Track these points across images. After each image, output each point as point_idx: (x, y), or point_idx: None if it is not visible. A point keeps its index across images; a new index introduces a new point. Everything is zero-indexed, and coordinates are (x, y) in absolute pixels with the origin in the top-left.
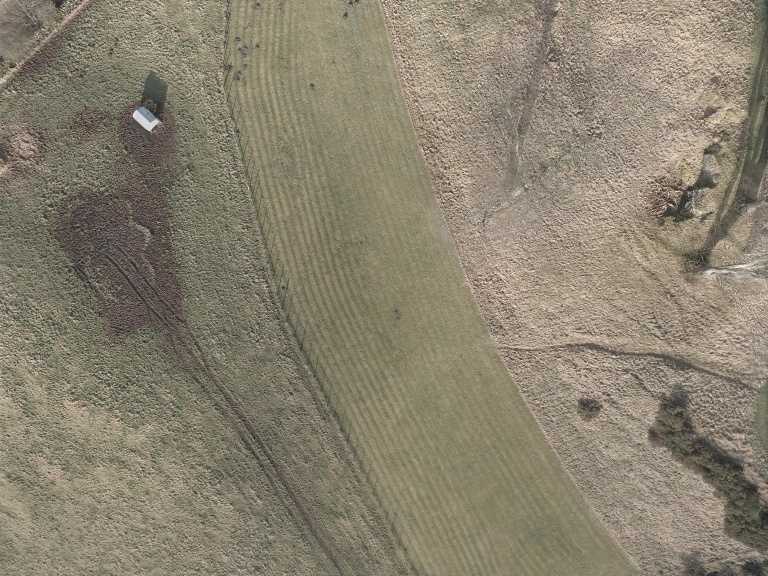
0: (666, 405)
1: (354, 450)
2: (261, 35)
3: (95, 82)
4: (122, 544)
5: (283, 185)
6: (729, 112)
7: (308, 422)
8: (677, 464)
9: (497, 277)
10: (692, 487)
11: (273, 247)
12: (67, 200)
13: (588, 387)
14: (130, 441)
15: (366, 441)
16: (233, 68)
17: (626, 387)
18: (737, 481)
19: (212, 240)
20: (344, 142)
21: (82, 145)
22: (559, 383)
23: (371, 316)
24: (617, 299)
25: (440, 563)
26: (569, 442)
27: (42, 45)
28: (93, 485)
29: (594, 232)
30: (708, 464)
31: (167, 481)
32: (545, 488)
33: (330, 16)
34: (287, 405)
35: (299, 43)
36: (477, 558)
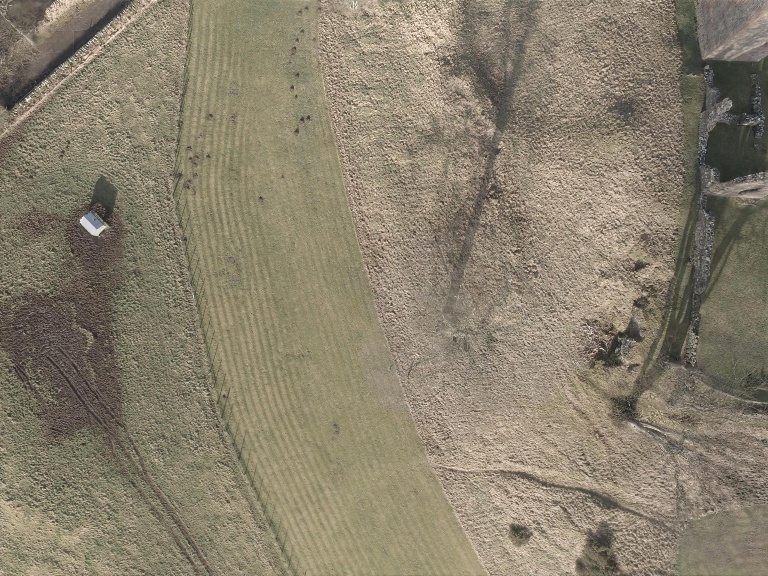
0: (592, 542)
1: (289, 559)
2: (212, 146)
3: (45, 184)
4: None
5: (228, 295)
6: (657, 270)
7: (244, 530)
8: None
9: (435, 398)
10: None
11: (216, 356)
12: (11, 300)
13: (519, 514)
14: (64, 542)
15: (301, 551)
16: (183, 177)
17: (555, 518)
18: None
19: (155, 346)
20: (290, 256)
21: (29, 246)
22: (492, 506)
23: (310, 429)
24: (548, 433)
25: None
26: (500, 564)
27: None
28: None
29: (528, 366)
30: None
31: None
32: None
33: (281, 131)
34: (223, 512)
35: (250, 156)
36: None
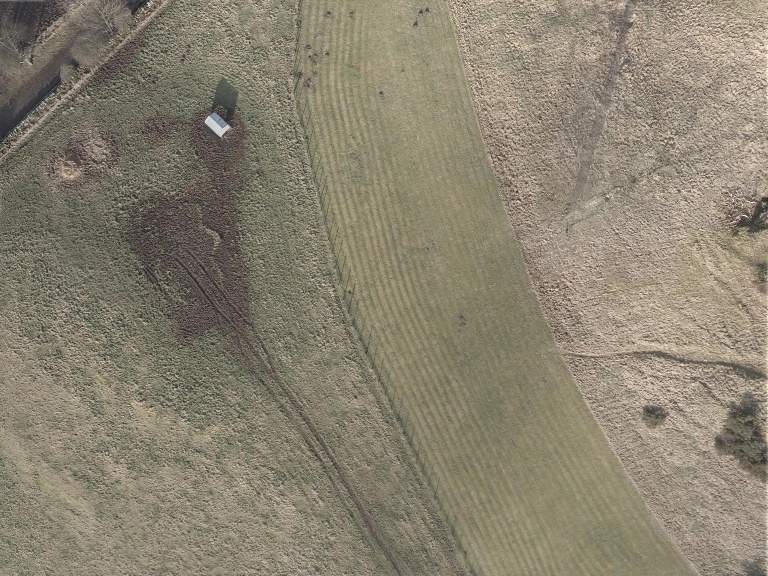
0: (736, 414)
1: (416, 453)
2: (331, 43)
3: (167, 88)
4: (185, 543)
5: (351, 191)
6: None
7: (371, 425)
8: (743, 472)
9: (564, 284)
10: (758, 495)
11: (340, 252)
12: (138, 204)
13: (654, 394)
14: (195, 441)
15: (429, 445)
16: (303, 75)
17: (694, 395)
18: None
19: (280, 244)
20: (412, 149)
21: (154, 150)
22: (624, 390)
23: (436, 321)
24: (687, 308)
25: (499, 567)
26: (633, 449)
27: (116, 51)
28: (158, 484)
29: (665, 241)
30: None
31: (231, 481)
32: (607, 494)
33: (400, 25)
34: (351, 408)
35: (369, 51)
36: (537, 562)
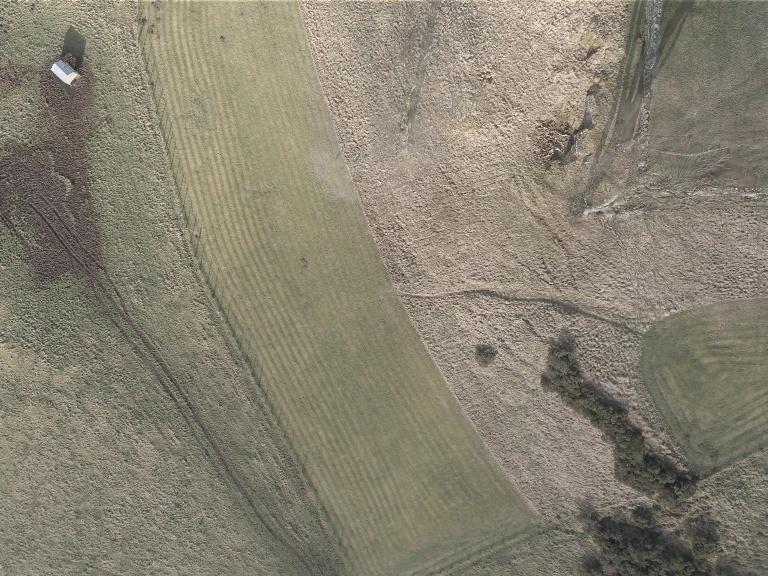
0: (554, 349)
1: (265, 394)
2: None
3: (18, 37)
4: (53, 479)
5: (195, 136)
6: (607, 51)
7: (222, 366)
8: (569, 409)
9: (398, 225)
10: (583, 432)
11: (186, 197)
12: None
13: (484, 333)
14: (56, 382)
15: (277, 385)
16: (147, 22)
17: (518, 332)
18: (620, 424)
19: (129, 190)
20: (252, 93)
21: (7, 98)
22: (458, 330)
23: (279, 264)
24: (508, 245)
25: (349, 504)
26: (469, 388)
27: None
28: (25, 423)
29: (486, 178)
30: (593, 407)
31: (92, 420)
32: (447, 433)
33: None
34: (201, 350)
35: None
36: (384, 500)
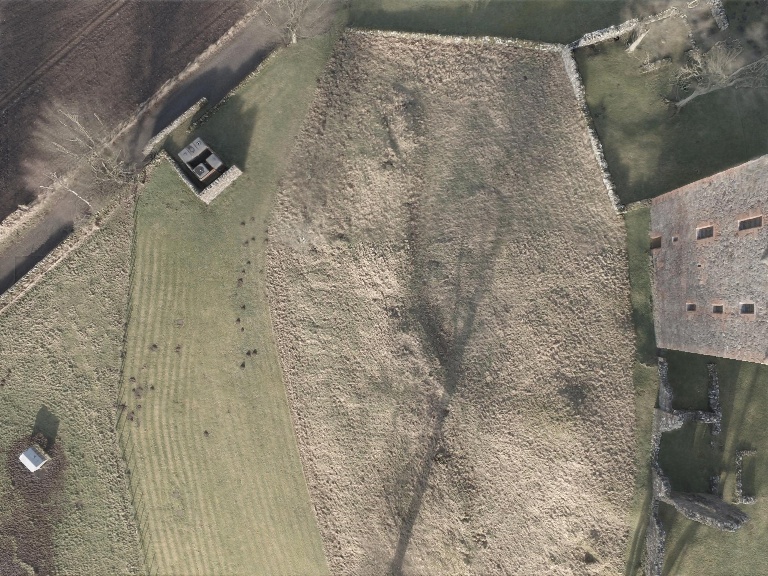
0: None
1: None
2: (157, 377)
3: None
4: None
5: (173, 530)
6: (606, 570)
7: None
8: None
9: None
10: None
11: None
12: None
13: None
14: None
15: None
16: (127, 408)
17: None
18: None
19: None
20: (236, 493)
21: None
22: None
23: None
24: None
25: None
26: None
27: None
28: None
29: None
30: None
31: None
32: None
33: (227, 365)
34: None
35: (195, 388)
36: None
